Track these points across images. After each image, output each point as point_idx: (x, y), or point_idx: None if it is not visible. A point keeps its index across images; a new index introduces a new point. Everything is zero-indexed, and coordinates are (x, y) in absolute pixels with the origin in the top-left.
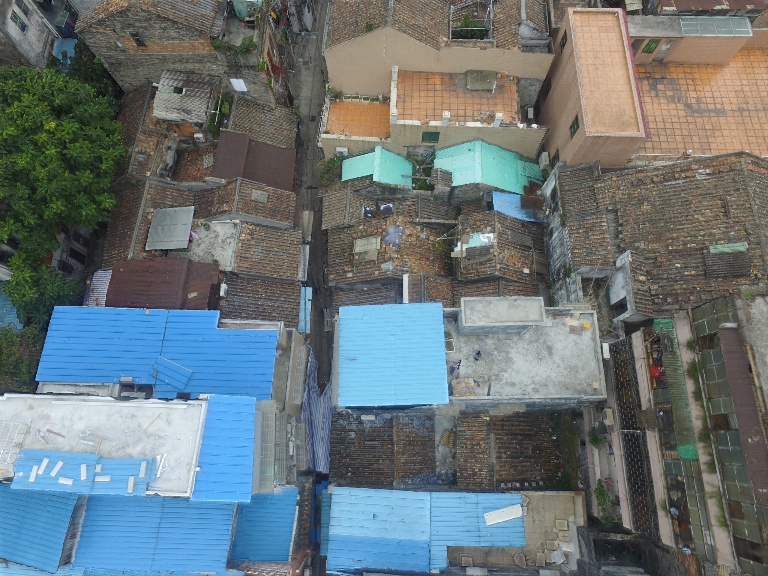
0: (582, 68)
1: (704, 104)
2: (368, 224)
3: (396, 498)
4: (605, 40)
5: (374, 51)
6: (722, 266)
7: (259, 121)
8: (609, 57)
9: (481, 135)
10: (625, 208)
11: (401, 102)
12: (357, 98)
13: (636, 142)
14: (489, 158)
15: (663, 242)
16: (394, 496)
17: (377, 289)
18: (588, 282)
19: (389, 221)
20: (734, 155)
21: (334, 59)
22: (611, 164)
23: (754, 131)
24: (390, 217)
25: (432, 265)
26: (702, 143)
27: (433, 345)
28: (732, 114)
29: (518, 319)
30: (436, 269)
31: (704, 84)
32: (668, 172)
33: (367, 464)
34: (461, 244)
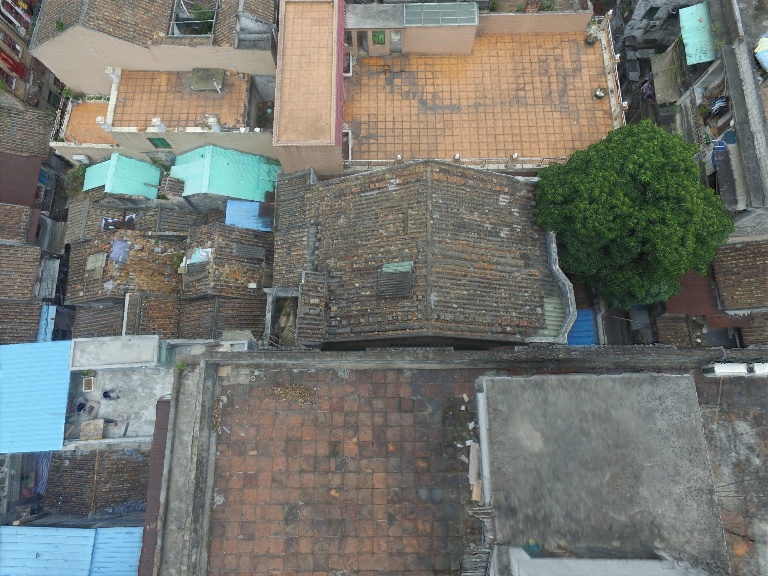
0: (285, 68)
1: (440, 100)
2: (101, 239)
3: (61, 536)
4: (316, 34)
5: (83, 51)
6: (390, 287)
7: (3, 126)
8: (316, 54)
9: (209, 140)
10: (325, 221)
11: (121, 106)
12: (100, 99)
13: (331, 150)
14: (222, 164)
15: (349, 259)
16: (60, 534)
17: (110, 308)
18: (289, 301)
19: (116, 236)
20: (422, 163)
21: (48, 60)
22: (329, 171)
23: (486, 129)
24: (117, 232)
25: (167, 280)
26: (429, 144)
27: (57, 387)
28: (467, 110)
29: (129, 360)
30: (172, 284)
31: (444, 77)
32: (365, 182)
33: (74, 493)
34: (185, 259)
